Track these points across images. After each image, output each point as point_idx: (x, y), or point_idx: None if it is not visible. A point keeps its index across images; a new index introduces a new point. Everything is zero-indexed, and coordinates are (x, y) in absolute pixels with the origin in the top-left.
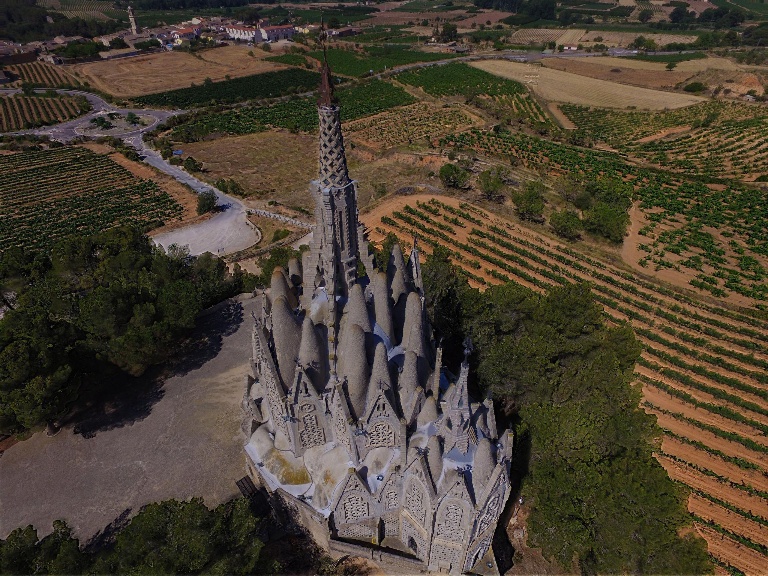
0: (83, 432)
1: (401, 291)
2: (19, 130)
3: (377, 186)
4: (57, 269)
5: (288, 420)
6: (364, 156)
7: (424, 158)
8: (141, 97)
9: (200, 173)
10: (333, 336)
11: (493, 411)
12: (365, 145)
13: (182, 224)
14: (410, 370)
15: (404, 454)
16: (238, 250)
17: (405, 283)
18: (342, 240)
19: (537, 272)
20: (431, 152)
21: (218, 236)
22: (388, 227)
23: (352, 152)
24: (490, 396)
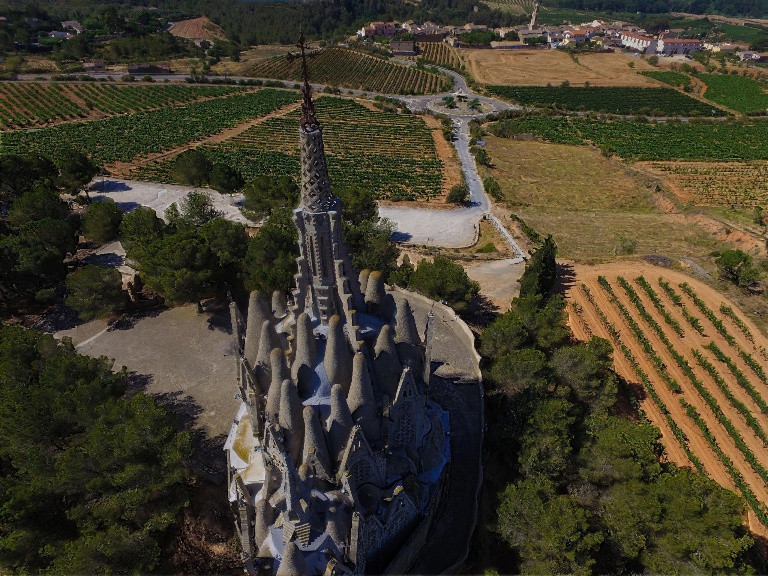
0: (211, 323)
1: (383, 348)
2: (394, 94)
3: (626, 241)
4: (298, 203)
5: (237, 398)
6: (663, 204)
7: (733, 232)
8: (496, 87)
9: (484, 167)
10: (291, 351)
11: (357, 531)
12: (673, 192)
13: (426, 205)
14: (306, 425)
15: (265, 498)
16: (446, 246)
17: (391, 342)
18: (314, 265)
19: (767, 447)
20: (752, 228)
21: (443, 227)
22: (600, 290)
23: (653, 195)
24: (355, 512)
